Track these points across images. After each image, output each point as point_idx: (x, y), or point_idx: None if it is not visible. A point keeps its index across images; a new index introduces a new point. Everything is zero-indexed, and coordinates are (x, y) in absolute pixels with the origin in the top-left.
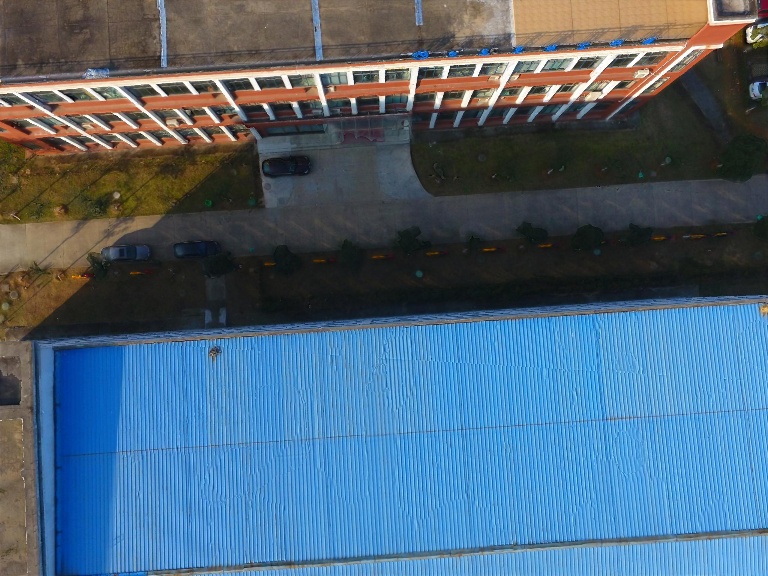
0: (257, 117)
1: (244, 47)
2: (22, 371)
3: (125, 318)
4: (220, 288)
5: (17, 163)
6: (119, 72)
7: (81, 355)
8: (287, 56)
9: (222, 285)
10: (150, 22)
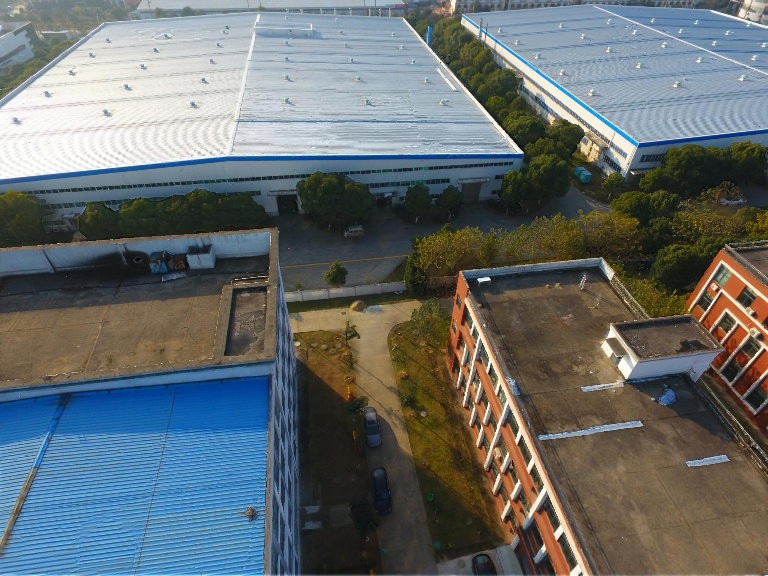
0: (531, 541)
1: (591, 515)
2: (251, 355)
3: (313, 431)
4: (343, 519)
5: (436, 344)
6: (520, 402)
7: (263, 394)
8: (602, 568)
9: (346, 521)
10: (575, 422)
